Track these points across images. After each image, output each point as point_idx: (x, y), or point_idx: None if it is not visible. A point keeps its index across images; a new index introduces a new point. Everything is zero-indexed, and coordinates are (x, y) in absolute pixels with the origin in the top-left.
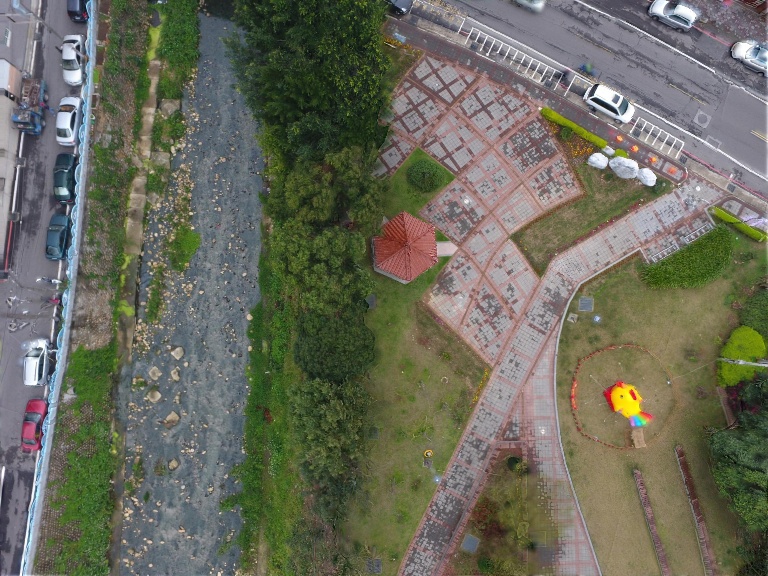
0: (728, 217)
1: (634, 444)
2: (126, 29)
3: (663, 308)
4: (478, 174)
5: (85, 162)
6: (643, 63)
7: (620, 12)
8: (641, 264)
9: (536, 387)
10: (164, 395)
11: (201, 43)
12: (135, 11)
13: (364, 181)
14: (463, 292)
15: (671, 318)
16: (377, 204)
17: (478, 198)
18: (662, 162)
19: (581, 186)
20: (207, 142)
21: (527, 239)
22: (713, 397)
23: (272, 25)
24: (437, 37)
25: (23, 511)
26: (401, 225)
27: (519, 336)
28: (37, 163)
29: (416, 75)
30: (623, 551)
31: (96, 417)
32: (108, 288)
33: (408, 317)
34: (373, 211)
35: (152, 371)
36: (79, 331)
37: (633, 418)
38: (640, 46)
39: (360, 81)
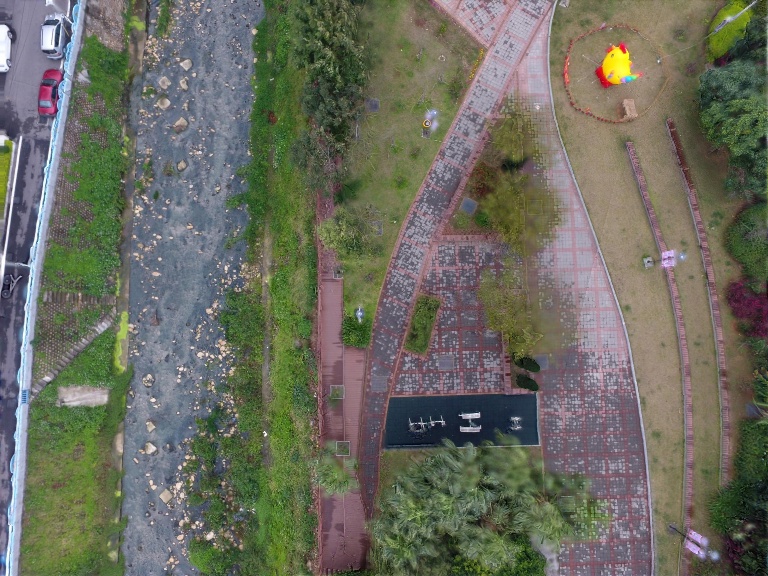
0: None
1: (626, 111)
2: None
3: None
4: None
5: None
6: None
7: None
8: None
9: (530, 67)
10: (173, 103)
11: None
12: None
13: None
14: None
15: None
16: None
17: None
18: None
19: None
20: None
21: None
22: None
23: None
24: None
25: (39, 176)
26: None
27: (513, 20)
28: None
29: None
30: (618, 218)
31: (108, 113)
32: None
33: (406, 1)
34: None
35: (162, 80)
36: (93, 21)
37: (624, 77)
38: None
39: None
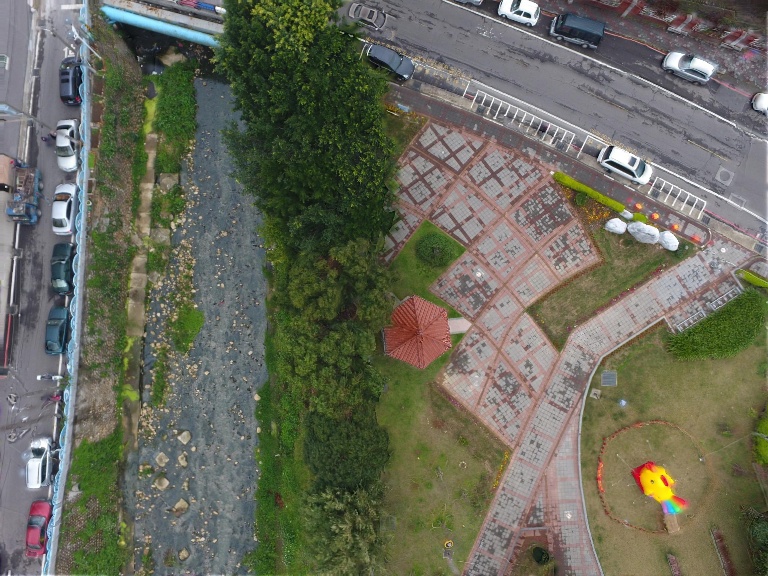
0: (757, 281)
1: (667, 529)
2: (121, 106)
3: (692, 381)
4: (490, 245)
5: (83, 250)
6: (659, 119)
7: (632, 67)
8: (666, 334)
9: (560, 469)
10: (172, 482)
11: (198, 113)
12: (129, 87)
13: (371, 273)
14: (479, 371)
15: (701, 391)
16: (386, 298)
17: (491, 270)
18: (684, 224)
19: (599, 253)
20: (207, 216)
21: (544, 312)
22: (749, 473)
23: (269, 116)
24: (441, 102)
25: None
26: (412, 310)
27: (540, 415)
28: (34, 253)
29: (421, 143)
30: None
31: (103, 510)
32: (111, 374)
33: (422, 400)
34: (382, 306)
35: (159, 457)
36: (82, 424)
37: (665, 504)
38: (655, 101)
39: (363, 169)
